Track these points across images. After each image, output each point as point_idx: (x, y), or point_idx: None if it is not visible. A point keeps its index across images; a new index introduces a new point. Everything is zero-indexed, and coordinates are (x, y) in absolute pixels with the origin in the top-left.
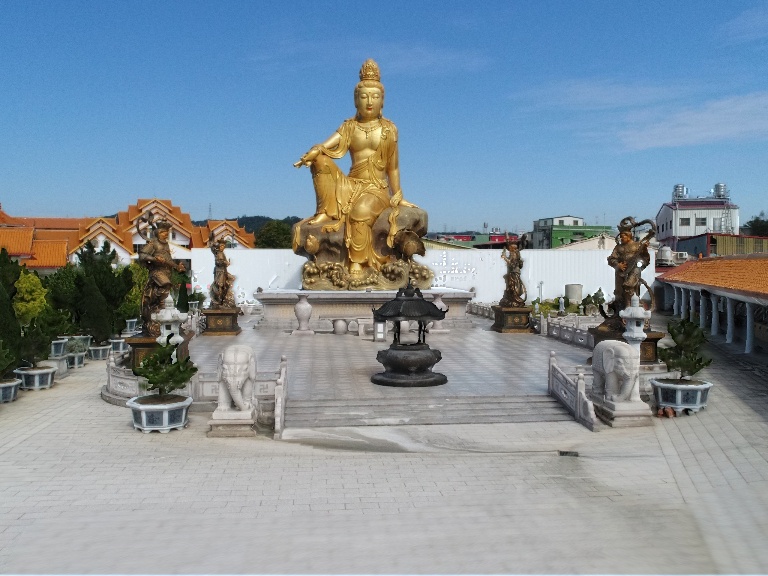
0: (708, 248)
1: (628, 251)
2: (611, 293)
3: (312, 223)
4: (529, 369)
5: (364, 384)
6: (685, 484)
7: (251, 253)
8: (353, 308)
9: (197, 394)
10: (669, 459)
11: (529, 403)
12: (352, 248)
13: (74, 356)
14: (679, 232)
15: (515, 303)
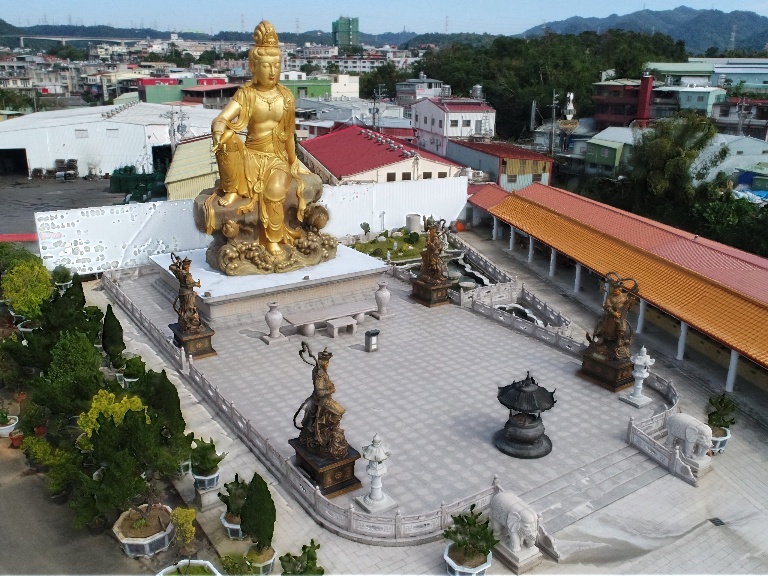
0: (500, 169)
1: (620, 302)
2: (435, 216)
3: (226, 205)
4: (558, 396)
5: (505, 459)
6: None
7: (107, 211)
8: (291, 295)
9: None
10: (767, 515)
11: (628, 459)
12: (270, 228)
13: (188, 463)
14: (449, 132)
15: (439, 281)
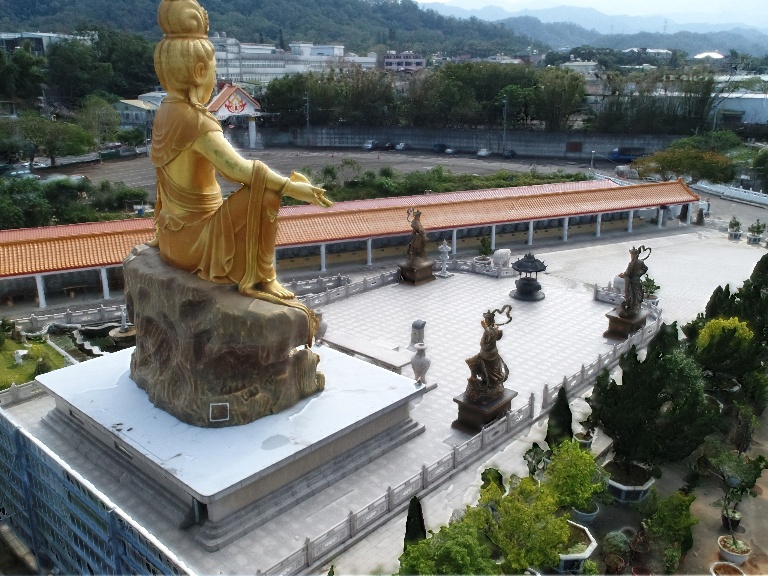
0: None
1: None
2: None
3: None
4: None
5: None
6: (549, 263)
7: None
8: None
9: None
10: None
11: None
12: None
13: None
14: None
15: None
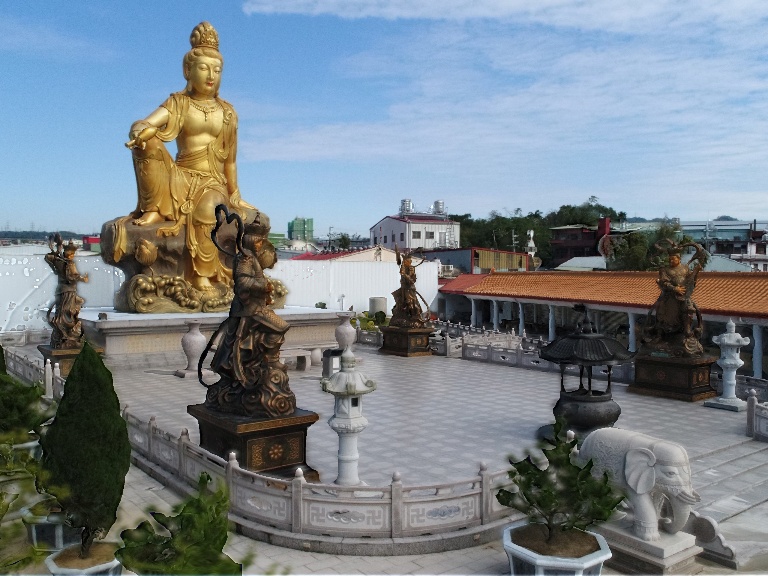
0: (472, 261)
1: (681, 274)
2: None
3: (142, 224)
4: None
5: None
6: None
7: None
8: None
9: (487, 511)
10: None
11: (763, 452)
12: (199, 258)
13: None
14: (412, 244)
15: (417, 323)
